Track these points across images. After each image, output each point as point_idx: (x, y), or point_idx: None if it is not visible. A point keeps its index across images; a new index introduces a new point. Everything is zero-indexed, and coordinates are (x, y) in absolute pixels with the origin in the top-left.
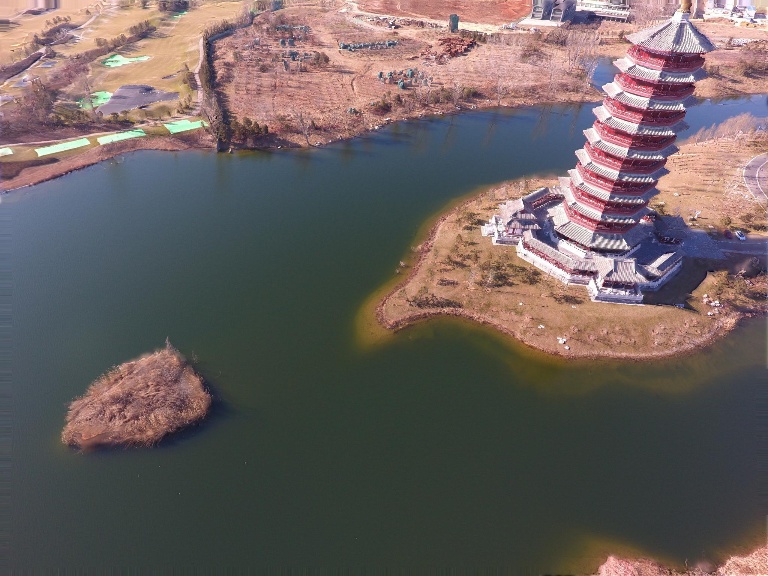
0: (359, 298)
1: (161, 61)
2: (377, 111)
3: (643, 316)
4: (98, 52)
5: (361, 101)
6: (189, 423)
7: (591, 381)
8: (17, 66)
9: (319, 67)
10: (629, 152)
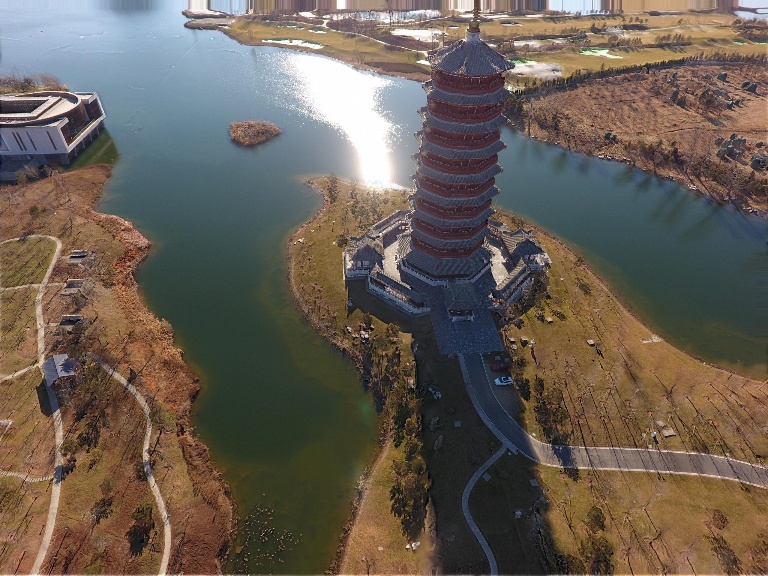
0: (334, 172)
1: (619, 62)
2: (633, 149)
3: (330, 277)
4: (605, 45)
5: (645, 138)
6: (239, 142)
7: (269, 257)
8: (542, 36)
9: (707, 110)
10: (418, 155)
